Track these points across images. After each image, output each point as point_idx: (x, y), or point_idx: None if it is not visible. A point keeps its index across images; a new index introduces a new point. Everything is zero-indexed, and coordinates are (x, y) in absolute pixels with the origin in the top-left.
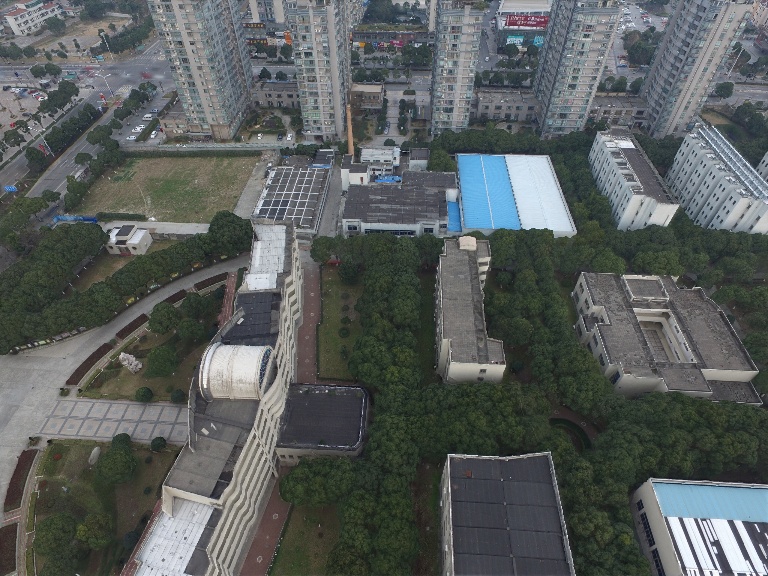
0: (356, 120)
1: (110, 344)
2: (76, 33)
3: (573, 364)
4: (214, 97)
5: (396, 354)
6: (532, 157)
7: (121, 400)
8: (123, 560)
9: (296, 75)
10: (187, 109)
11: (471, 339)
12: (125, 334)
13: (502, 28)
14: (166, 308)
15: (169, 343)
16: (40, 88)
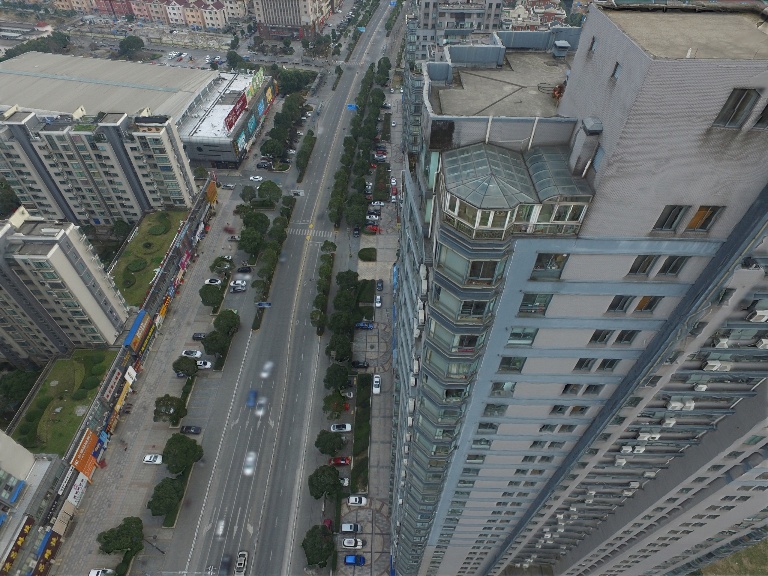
0: None
1: None
2: None
3: None
4: None
5: None
6: None
7: None
8: None
9: None
10: None
11: None
12: None
13: (229, 138)
14: None
15: None
16: None
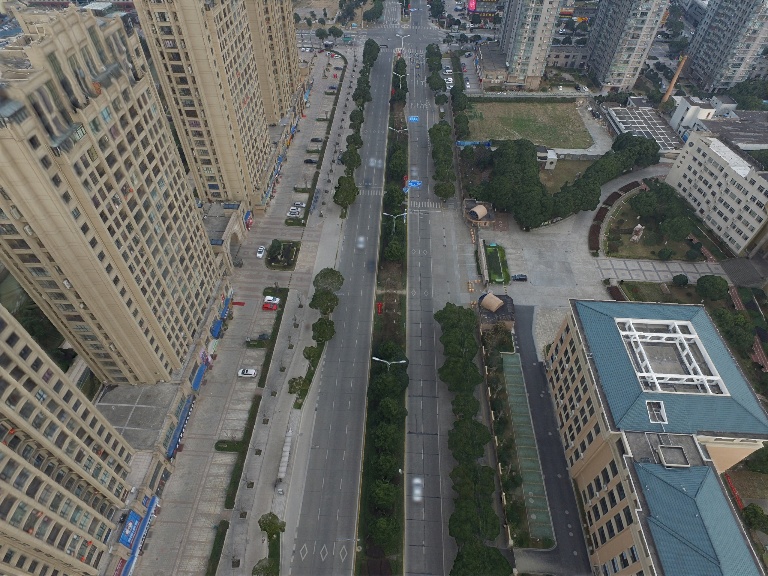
0: None
1: (599, 225)
2: (304, 5)
3: None
4: (543, 51)
5: None
6: None
7: (642, 259)
8: (752, 345)
9: (622, 33)
10: (516, 61)
11: None
12: (603, 219)
13: None
14: (654, 194)
15: (643, 225)
16: (324, 48)
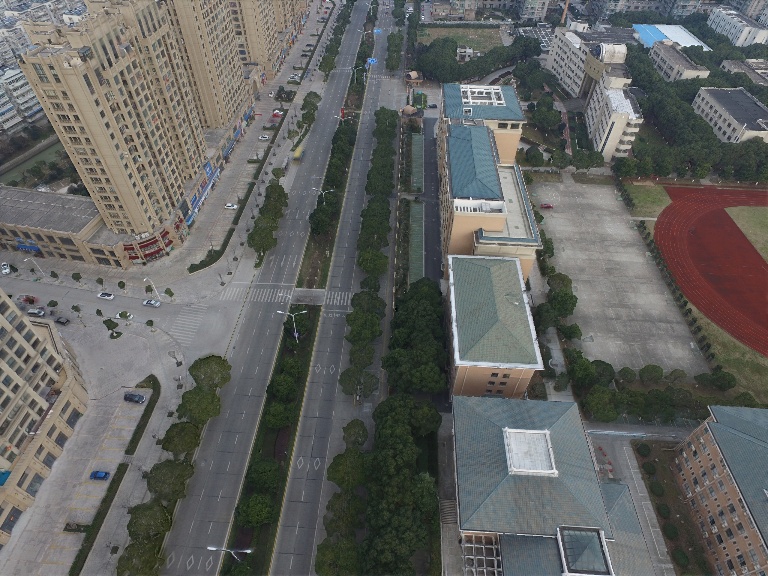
0: (546, 14)
1: None
2: None
3: (738, 75)
4: None
5: (654, 73)
6: (671, 26)
7: None
8: None
9: None
10: None
11: (689, 66)
12: (495, 83)
13: None
14: None
15: (521, 85)
16: None
